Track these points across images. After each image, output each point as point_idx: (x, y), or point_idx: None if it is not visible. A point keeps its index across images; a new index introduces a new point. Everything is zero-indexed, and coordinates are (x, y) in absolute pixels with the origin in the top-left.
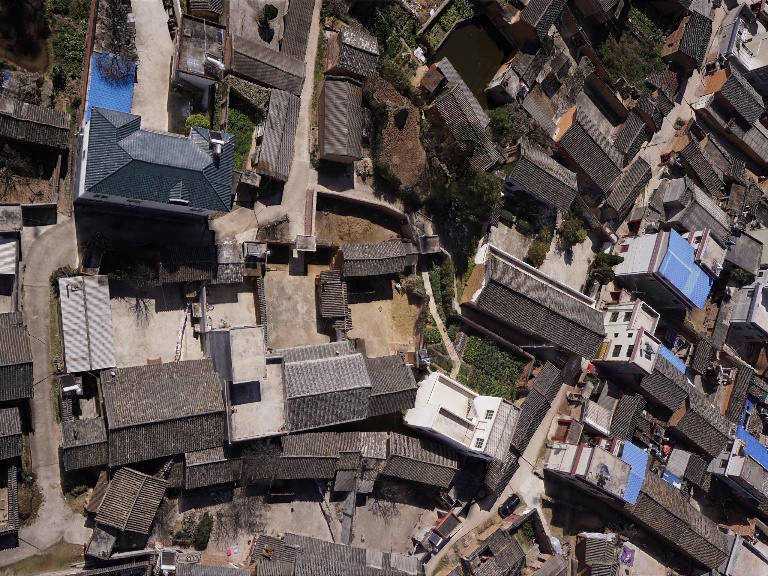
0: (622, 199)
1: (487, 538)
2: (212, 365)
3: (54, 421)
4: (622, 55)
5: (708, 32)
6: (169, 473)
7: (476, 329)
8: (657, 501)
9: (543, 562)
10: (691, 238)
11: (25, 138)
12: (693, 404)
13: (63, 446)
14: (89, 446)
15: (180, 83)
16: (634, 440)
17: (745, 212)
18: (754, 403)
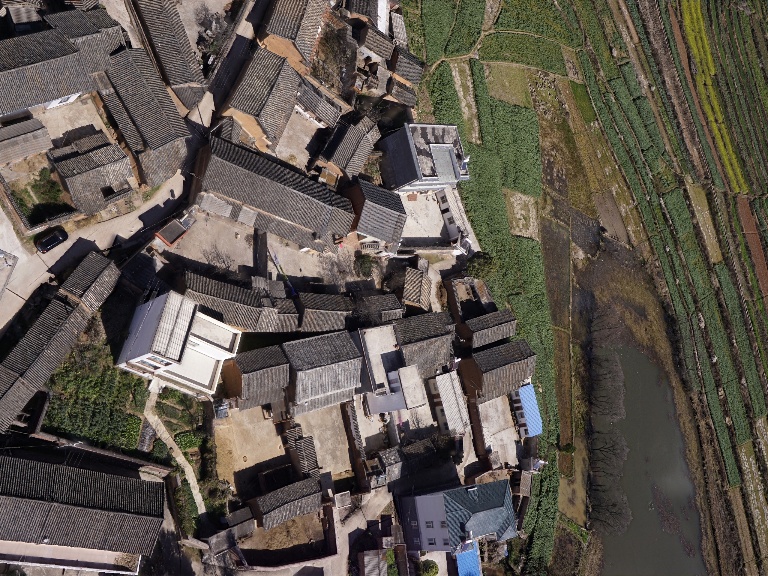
0: None
1: None
2: None
3: None
4: None
5: None
6: None
7: None
8: None
9: None
10: None
11: None
12: None
13: None
14: None
15: None
16: None
17: None
18: None
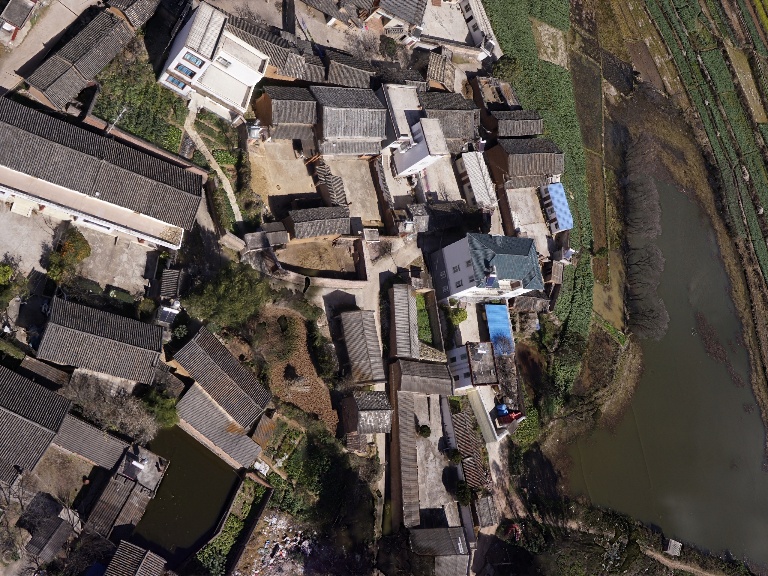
0: None
1: None
2: None
3: None
4: None
5: None
6: None
7: None
8: None
9: None
10: None
11: None
12: None
13: None
14: None
15: None
16: None
17: None
18: None
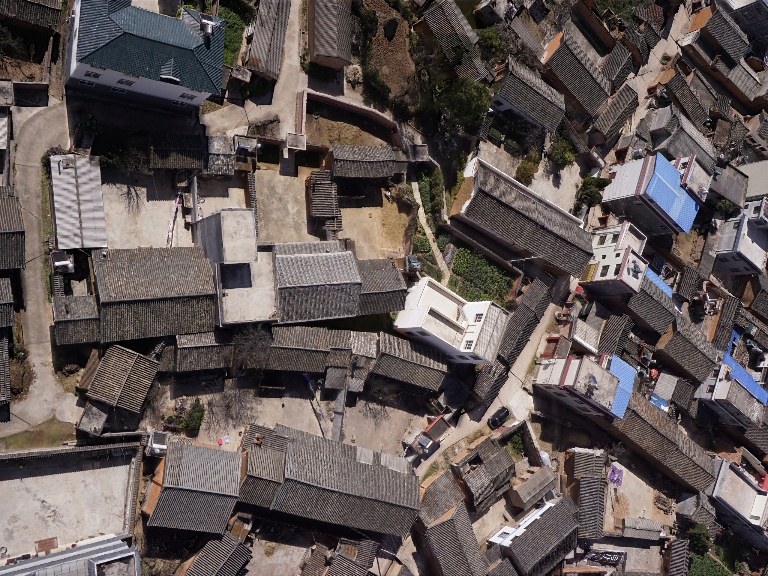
0: (609, 124)
1: (477, 446)
2: (203, 253)
3: (46, 300)
4: None
5: None
6: (160, 356)
7: (465, 242)
8: (645, 419)
9: (532, 474)
10: (677, 164)
11: (17, 16)
12: (680, 327)
13: (55, 319)
14: (81, 321)
15: None
16: None
17: (731, 149)
18: (740, 334)
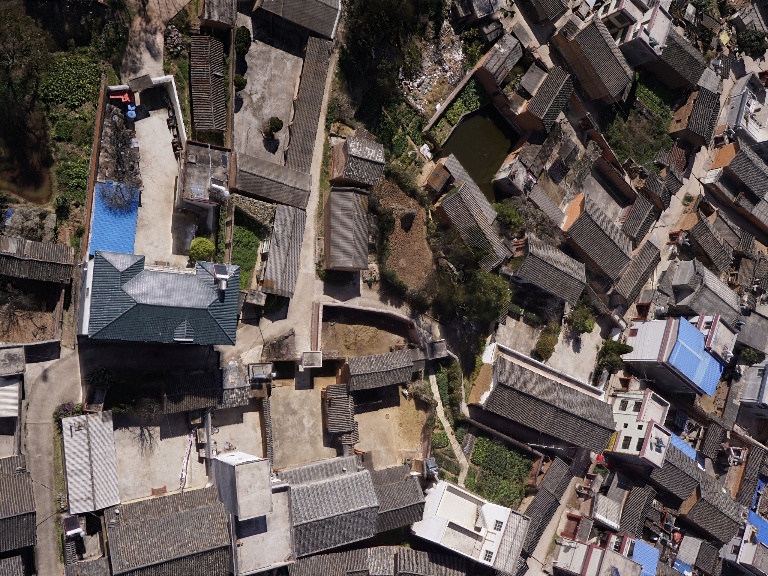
0: (631, 286)
1: None
2: (217, 493)
3: (57, 561)
4: (630, 134)
5: (716, 108)
6: None
7: (484, 429)
8: None
9: None
10: (701, 323)
11: (28, 276)
12: (704, 492)
13: None
14: None
15: (184, 207)
16: (644, 528)
17: (755, 286)
18: (765, 482)
